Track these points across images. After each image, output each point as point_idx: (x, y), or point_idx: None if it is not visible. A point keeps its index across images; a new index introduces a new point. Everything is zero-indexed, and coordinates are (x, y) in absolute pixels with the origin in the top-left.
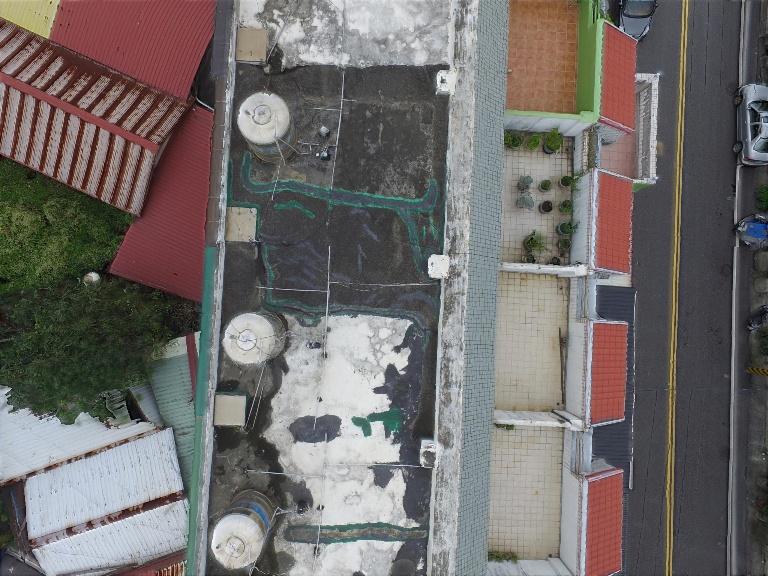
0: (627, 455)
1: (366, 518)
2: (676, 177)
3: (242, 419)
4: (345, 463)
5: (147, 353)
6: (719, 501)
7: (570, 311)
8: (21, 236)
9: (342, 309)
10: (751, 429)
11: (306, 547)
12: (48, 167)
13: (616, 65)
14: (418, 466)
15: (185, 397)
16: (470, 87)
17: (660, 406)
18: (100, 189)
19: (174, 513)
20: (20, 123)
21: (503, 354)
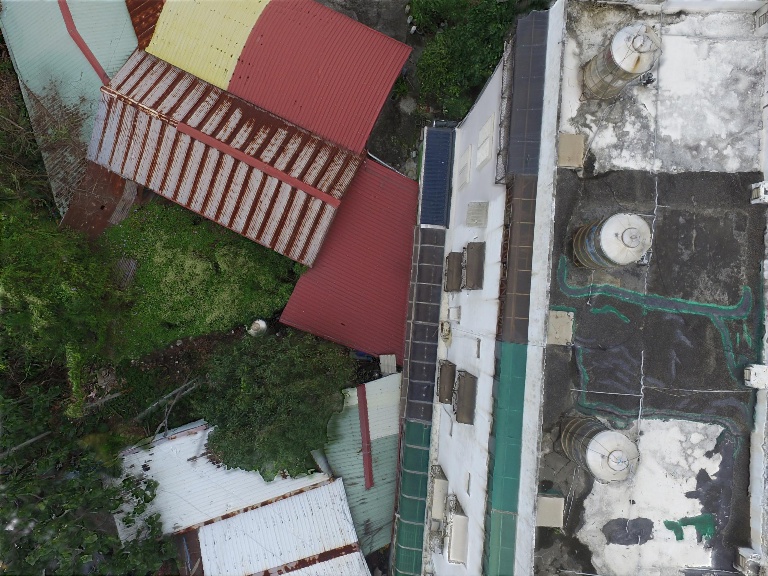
0: None
1: None
2: None
3: (561, 521)
4: (658, 566)
5: (338, 410)
6: None
7: None
8: (193, 283)
9: (655, 413)
10: None
11: None
12: (224, 217)
13: None
14: (731, 572)
15: (354, 447)
16: None
17: None
18: (274, 240)
19: (348, 564)
20: (201, 174)
21: None
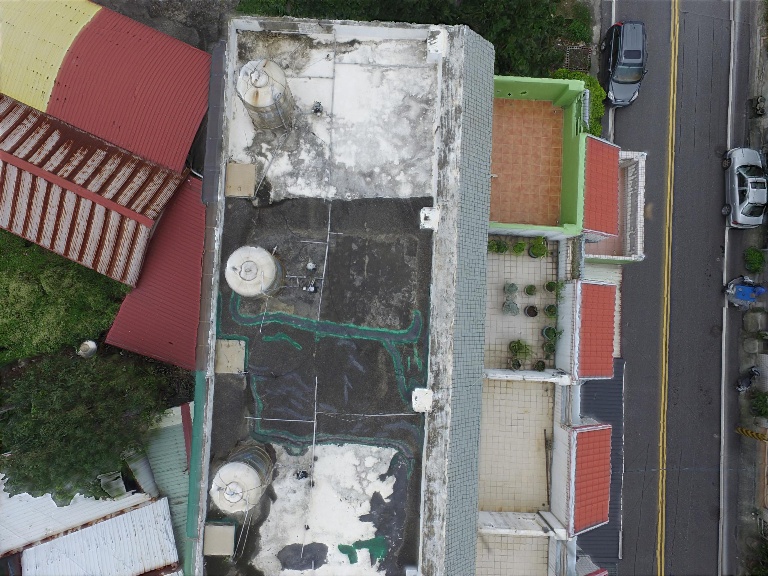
0: (616, 525)
1: None
2: (666, 239)
3: (231, 549)
4: None
5: (142, 432)
6: (709, 561)
7: (555, 414)
8: (18, 306)
9: (329, 438)
10: (741, 489)
11: None
12: (45, 239)
13: (599, 175)
14: None
15: (180, 466)
16: (453, 224)
17: (651, 466)
18: (96, 261)
19: None
20: (17, 197)
21: (489, 456)
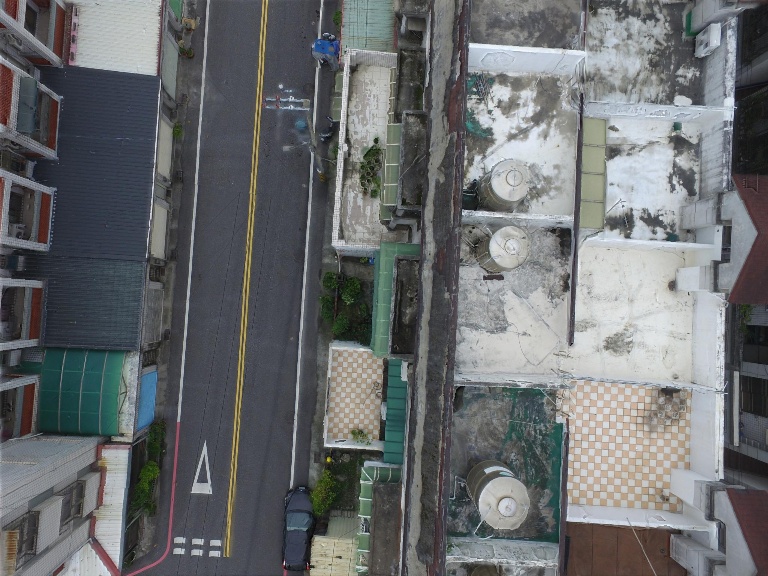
0: (145, 227)
1: None
2: (262, 2)
3: None
4: None
5: None
6: (294, 300)
7: None
8: None
9: None
10: (326, 234)
11: None
12: None
13: None
14: None
15: None
16: None
17: (241, 213)
18: None
19: None
20: None
21: None
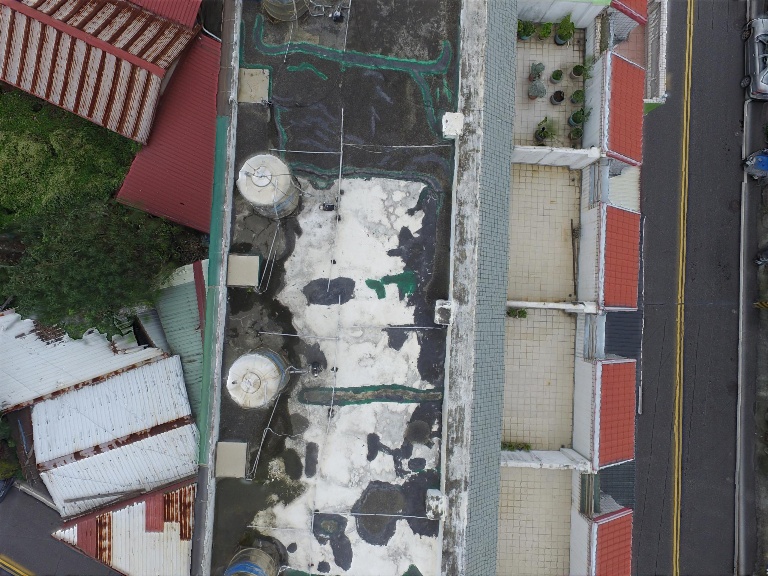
0: None
1: (380, 380)
2: (684, 112)
3: (255, 279)
4: (359, 325)
5: (155, 271)
6: (727, 437)
7: (582, 202)
8: (27, 165)
9: (355, 172)
10: (759, 365)
11: (320, 409)
12: (54, 95)
13: None
14: (433, 327)
15: (192, 325)
16: None
17: (668, 342)
18: (106, 117)
19: (182, 438)
20: (26, 49)
21: (515, 246)
